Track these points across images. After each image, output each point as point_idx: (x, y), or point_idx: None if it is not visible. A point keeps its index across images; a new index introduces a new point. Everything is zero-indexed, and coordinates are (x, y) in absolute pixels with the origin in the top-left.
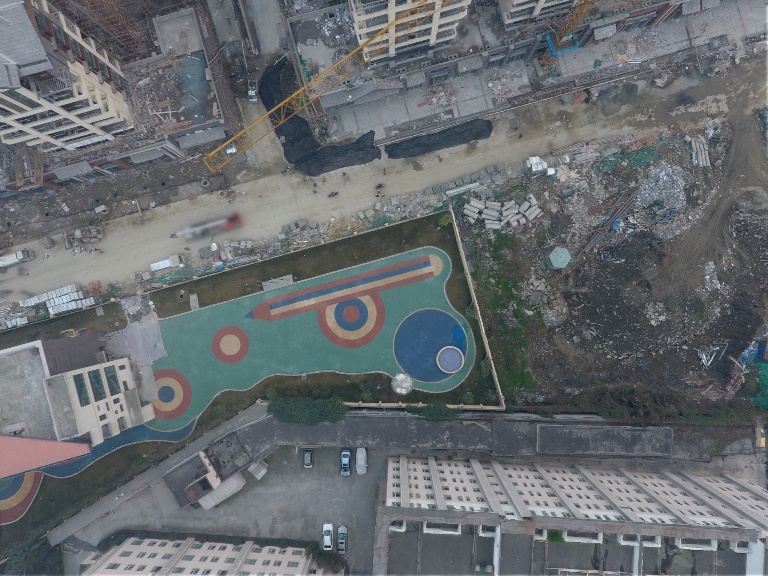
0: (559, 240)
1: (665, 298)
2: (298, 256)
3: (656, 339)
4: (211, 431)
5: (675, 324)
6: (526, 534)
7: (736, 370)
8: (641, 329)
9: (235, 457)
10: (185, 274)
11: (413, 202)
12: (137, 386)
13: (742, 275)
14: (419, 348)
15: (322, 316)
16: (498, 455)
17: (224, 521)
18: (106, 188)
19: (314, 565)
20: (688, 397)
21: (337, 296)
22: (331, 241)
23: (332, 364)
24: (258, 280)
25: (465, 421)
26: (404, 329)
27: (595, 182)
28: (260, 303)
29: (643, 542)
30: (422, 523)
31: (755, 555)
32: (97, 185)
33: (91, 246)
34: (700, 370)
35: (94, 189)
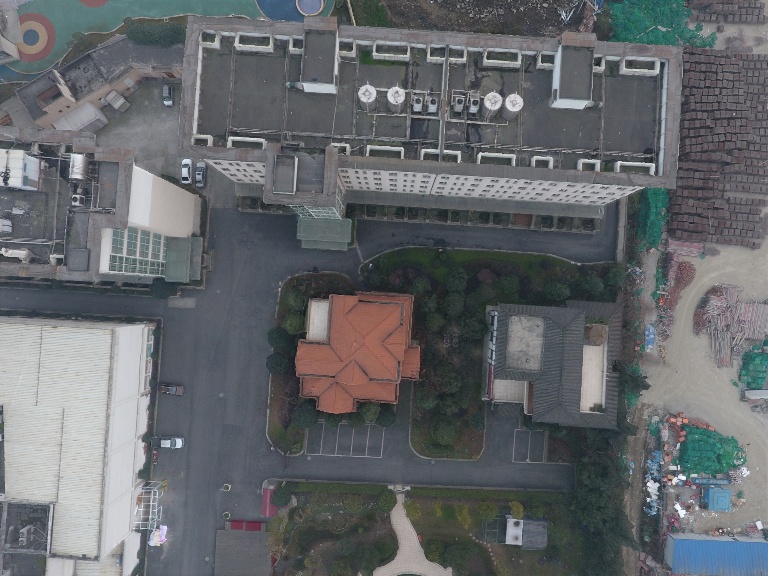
0: None
1: None
2: None
3: None
4: None
5: None
6: (328, 30)
7: (588, 10)
8: None
9: (92, 82)
10: None
11: None
12: (2, 29)
13: None
14: None
15: None
16: None
17: None
18: None
19: None
20: None
21: None
22: None
23: (194, 8)
24: None
25: None
26: None
27: None
28: None
29: None
30: None
31: (557, 64)
32: None
33: None
34: (559, 25)
35: None
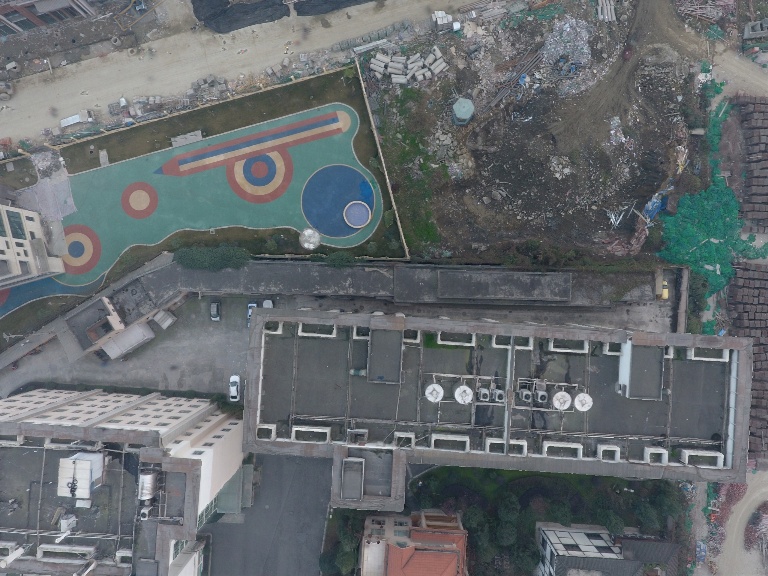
0: (466, 97)
1: (570, 152)
2: (207, 112)
3: (564, 197)
4: (118, 281)
5: (582, 180)
6: (395, 329)
7: (640, 223)
8: (546, 183)
9: (140, 305)
10: (95, 130)
11: (321, 58)
12: (47, 241)
13: (647, 130)
14: (327, 203)
15: (231, 172)
16: (399, 301)
17: (133, 374)
18: (18, 46)
19: (218, 412)
20: (594, 252)
21: (246, 152)
22: (239, 96)
23: (240, 219)
24: (167, 136)
25: (367, 268)
26: (312, 185)
27: (502, 39)
28: (169, 159)
29: (516, 346)
30: (298, 328)
31: (625, 356)
32: (9, 43)
33: (2, 103)
34: (609, 229)
35: (6, 47)
